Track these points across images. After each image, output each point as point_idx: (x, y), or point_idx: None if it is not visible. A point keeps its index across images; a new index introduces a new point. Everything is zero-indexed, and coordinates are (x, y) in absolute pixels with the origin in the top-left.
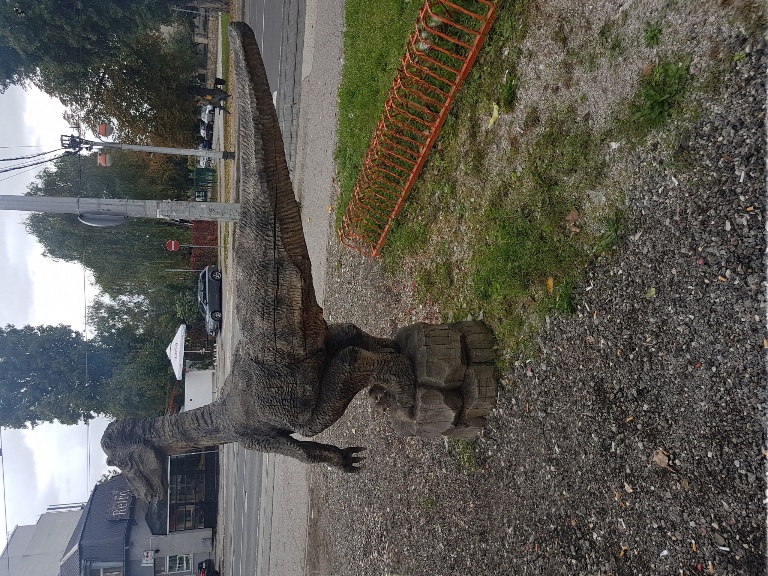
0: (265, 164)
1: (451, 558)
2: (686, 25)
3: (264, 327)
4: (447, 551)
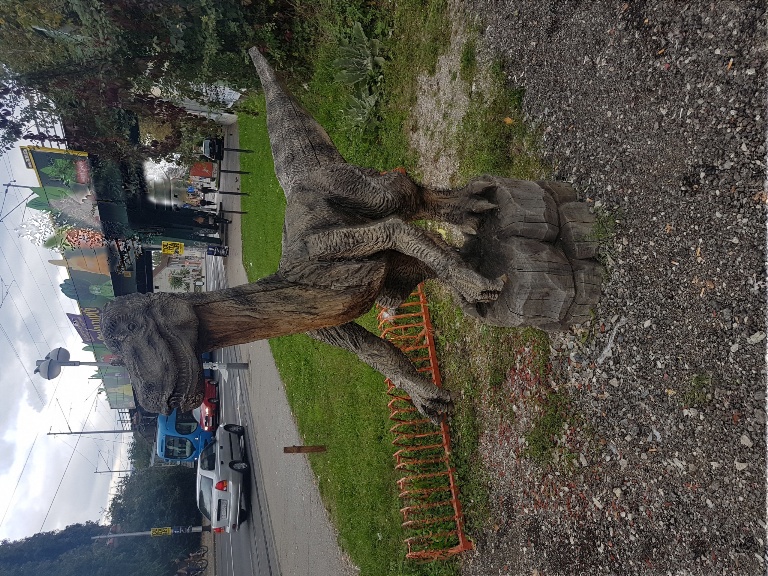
0: (277, 80)
1: (763, 293)
2: (456, 55)
3: (303, 147)
4: (760, 316)
